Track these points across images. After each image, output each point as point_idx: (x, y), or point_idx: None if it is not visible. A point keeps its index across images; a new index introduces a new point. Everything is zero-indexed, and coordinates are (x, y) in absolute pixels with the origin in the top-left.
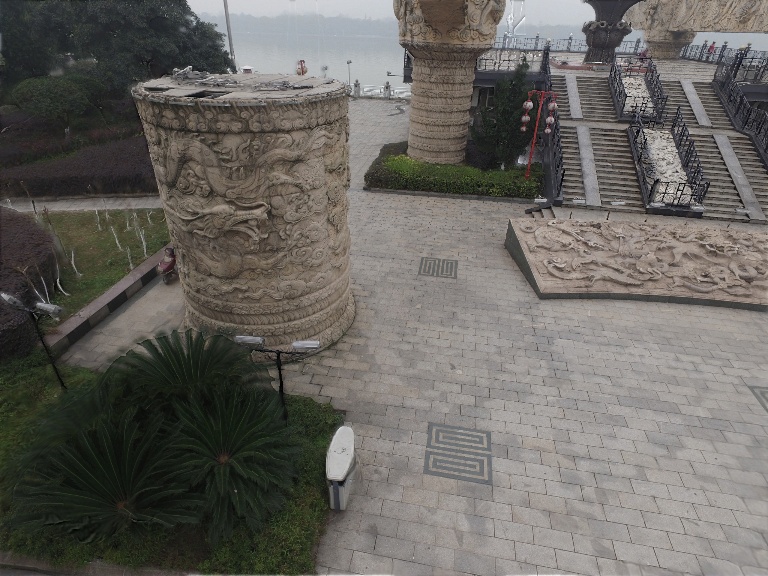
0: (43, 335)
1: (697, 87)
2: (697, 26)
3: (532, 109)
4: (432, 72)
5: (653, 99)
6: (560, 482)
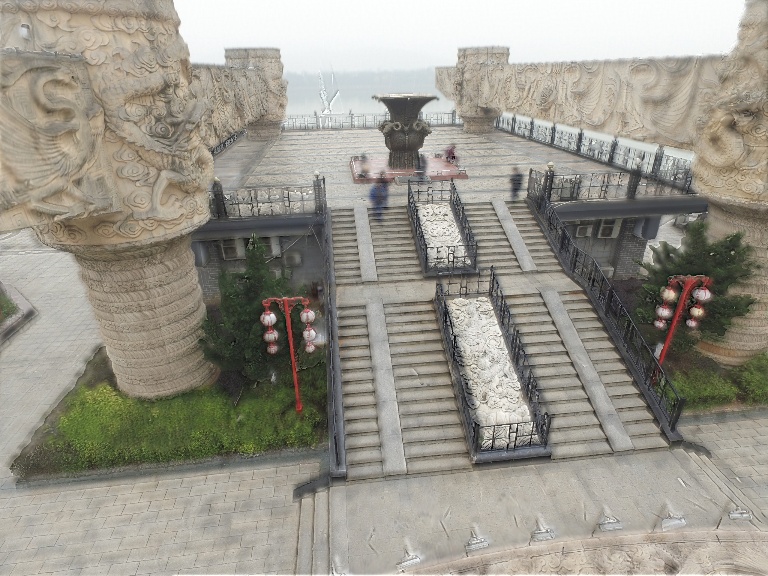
0: None
1: (511, 208)
2: (503, 106)
3: None
4: (103, 277)
5: (463, 237)
6: None
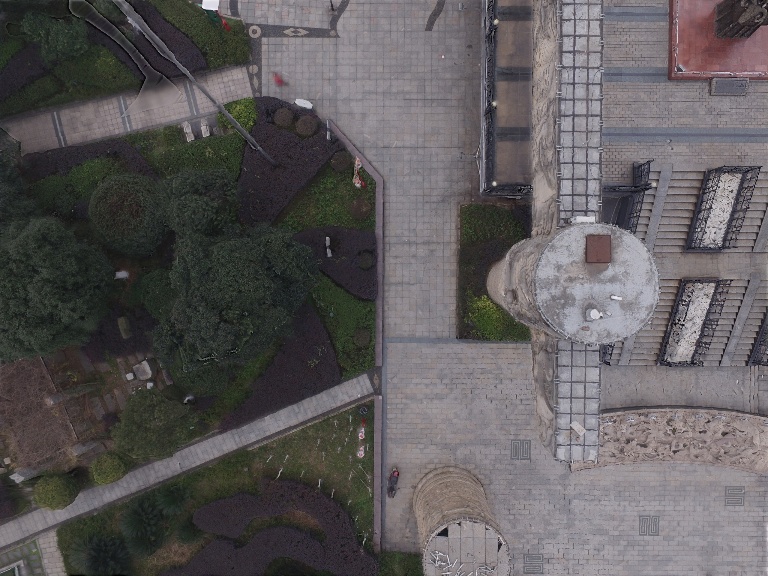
0: (372, 547)
1: None
2: None
3: None
4: None
5: (731, 219)
6: (563, 569)
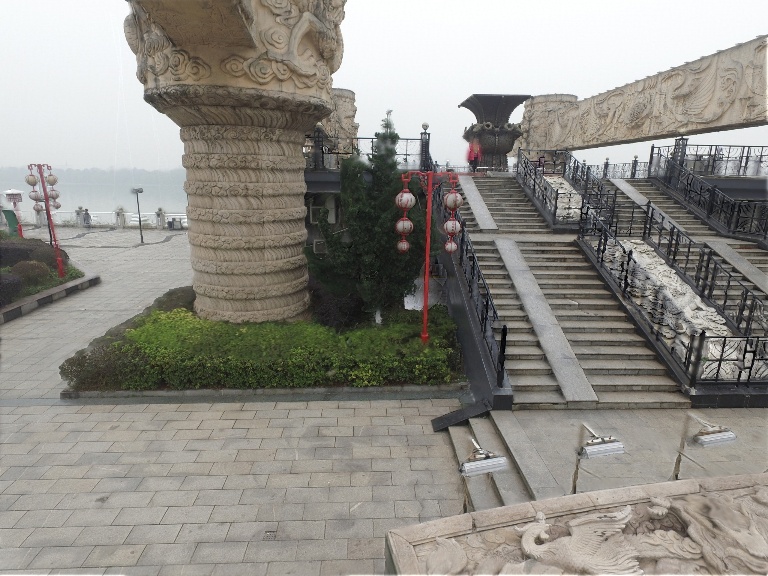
0: None
1: (633, 185)
2: (578, 142)
3: (415, 211)
4: (212, 148)
5: None
6: None
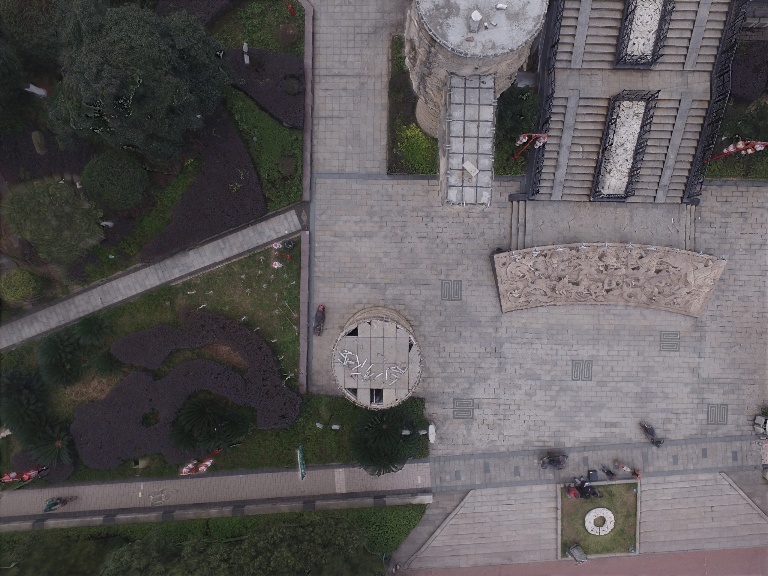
0: (298, 387)
1: None
2: None
3: None
4: None
5: (659, 28)
6: (493, 414)
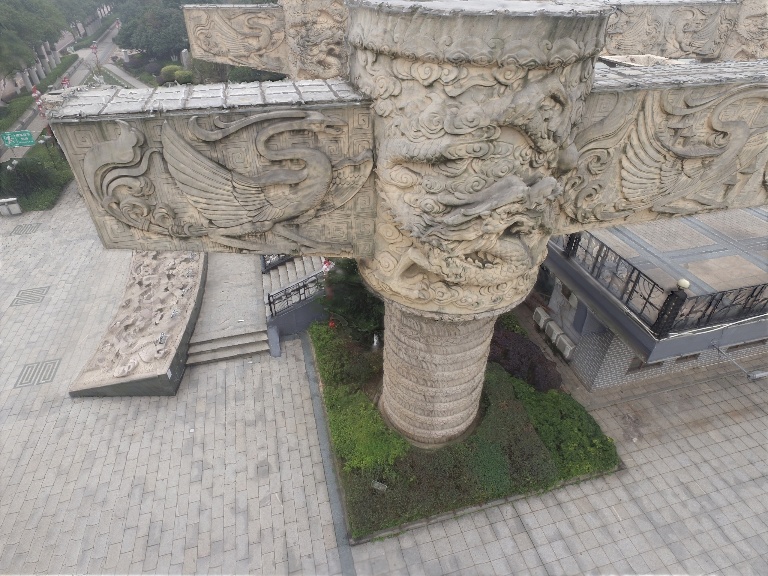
0: None
1: None
2: None
3: None
4: None
5: None
6: (6, 246)
